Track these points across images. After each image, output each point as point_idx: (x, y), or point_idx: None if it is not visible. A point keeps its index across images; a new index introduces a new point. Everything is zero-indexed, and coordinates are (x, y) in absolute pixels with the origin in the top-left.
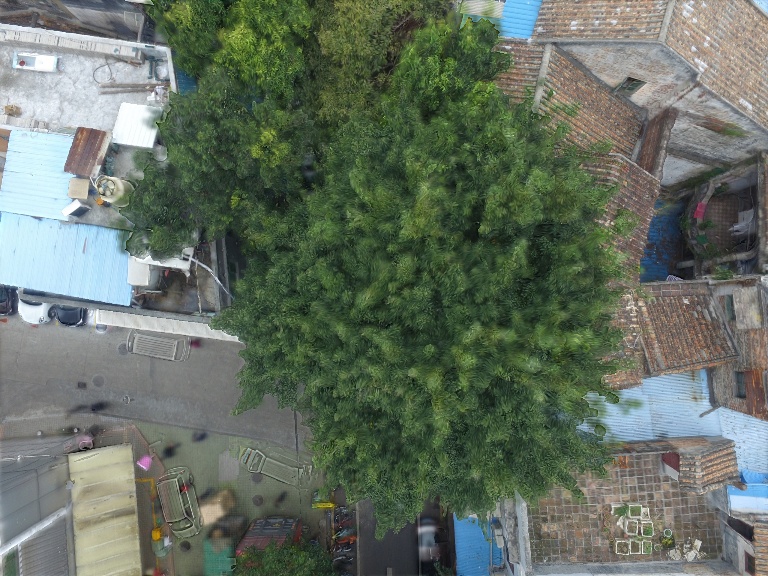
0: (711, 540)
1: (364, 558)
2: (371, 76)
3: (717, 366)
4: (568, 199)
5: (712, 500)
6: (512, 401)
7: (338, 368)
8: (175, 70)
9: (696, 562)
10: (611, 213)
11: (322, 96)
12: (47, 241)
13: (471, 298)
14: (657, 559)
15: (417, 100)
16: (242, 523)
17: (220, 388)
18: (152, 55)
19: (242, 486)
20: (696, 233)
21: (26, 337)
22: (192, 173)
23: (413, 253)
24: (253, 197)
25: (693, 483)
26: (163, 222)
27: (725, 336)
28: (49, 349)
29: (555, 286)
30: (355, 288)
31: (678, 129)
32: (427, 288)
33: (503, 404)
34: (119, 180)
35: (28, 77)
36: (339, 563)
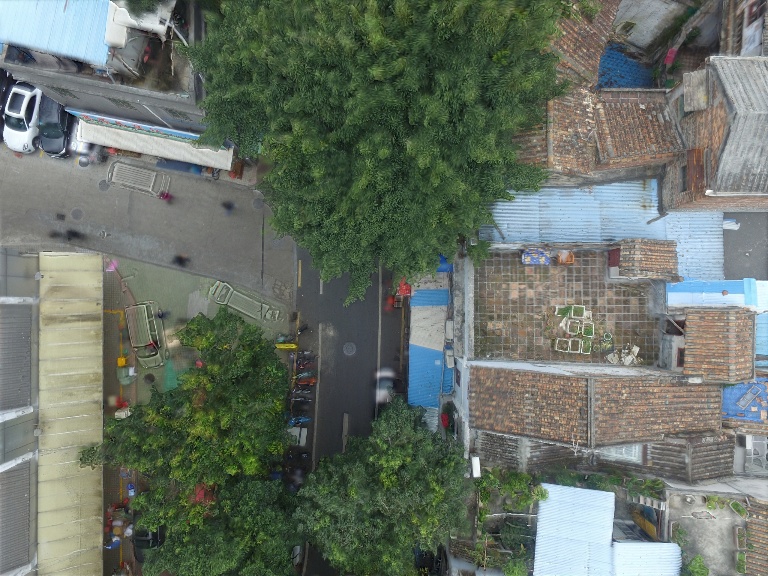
0: (649, 347)
1: (322, 403)
2: None
3: (667, 172)
4: None
5: (653, 308)
6: (450, 78)
7: None
8: None
9: (632, 366)
10: None
11: None
12: None
13: None
14: (595, 361)
15: None
16: None
17: (195, 230)
18: None
19: None
20: (665, 80)
21: (9, 167)
22: None
23: None
24: None
25: (631, 266)
26: None
27: (675, 135)
28: (31, 180)
29: None
30: None
31: None
32: None
33: (441, 78)
34: None
35: None
36: (298, 405)
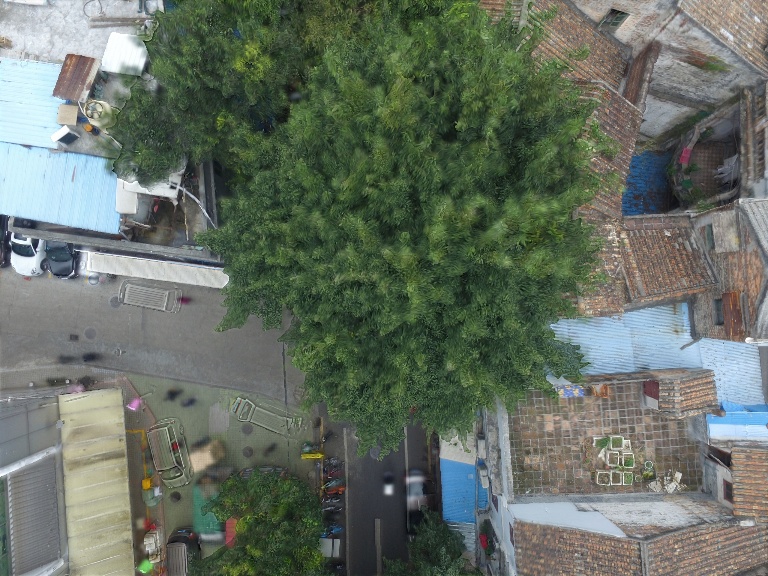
0: (691, 472)
1: (353, 509)
2: (357, 6)
3: (698, 298)
4: (543, 94)
5: (692, 433)
6: (487, 294)
7: (318, 266)
8: (164, 3)
9: (676, 493)
10: (593, 140)
11: (309, 25)
12: (36, 170)
13: (448, 193)
14: (638, 491)
15: (401, 22)
16: None
17: (211, 341)
18: None
19: (232, 438)
20: (681, 179)
21: (19, 290)
22: (178, 89)
23: (391, 149)
24: (239, 119)
25: (672, 408)
26: (150, 145)
27: (705, 266)
28: (41, 302)
29: (531, 183)
30: (335, 190)
31: (662, 67)
32: (405, 185)
33: (478, 296)
34: (107, 104)
35: (19, 11)
36: (328, 514)
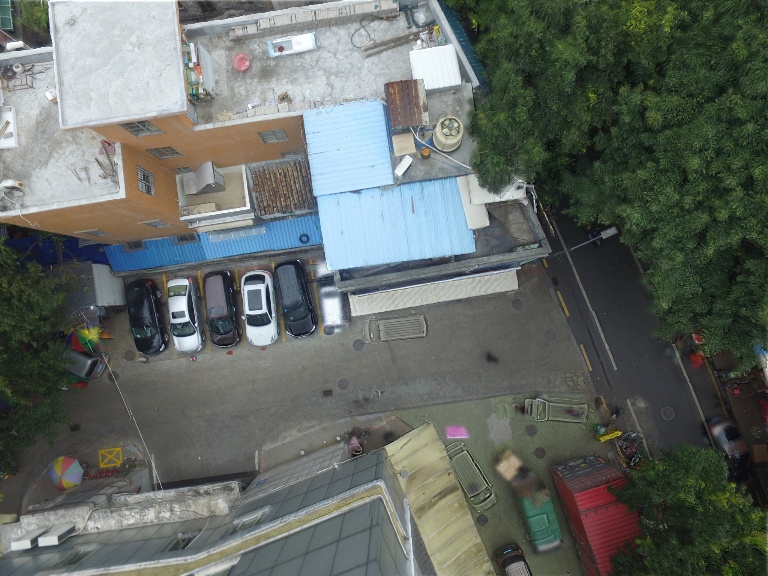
0: None
1: None
2: None
3: None
4: None
5: None
6: None
7: None
8: (441, 9)
9: None
10: None
11: None
12: (373, 212)
13: None
14: None
15: None
16: (532, 480)
17: (466, 355)
18: (406, 4)
19: (520, 444)
20: None
21: (257, 363)
22: (572, 72)
23: None
24: (609, 90)
25: None
26: None
27: None
28: (283, 367)
29: None
30: None
31: None
32: None
33: None
34: (456, 118)
35: (286, 63)
36: None
